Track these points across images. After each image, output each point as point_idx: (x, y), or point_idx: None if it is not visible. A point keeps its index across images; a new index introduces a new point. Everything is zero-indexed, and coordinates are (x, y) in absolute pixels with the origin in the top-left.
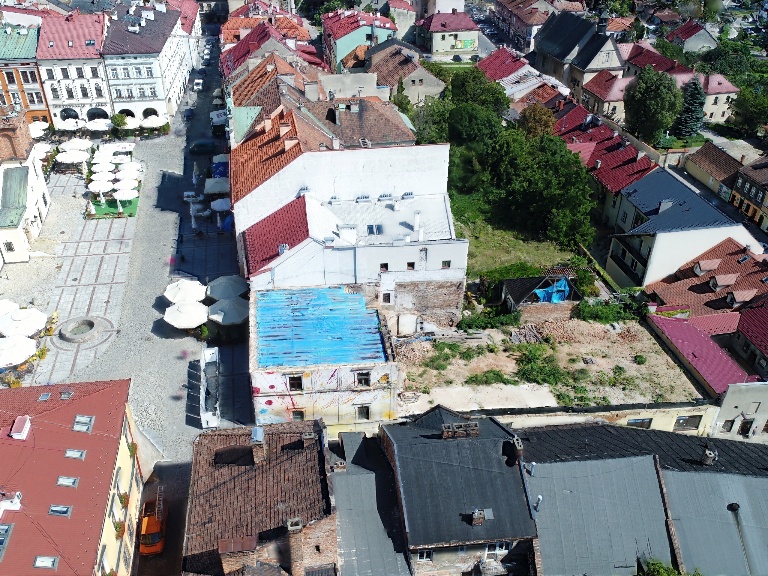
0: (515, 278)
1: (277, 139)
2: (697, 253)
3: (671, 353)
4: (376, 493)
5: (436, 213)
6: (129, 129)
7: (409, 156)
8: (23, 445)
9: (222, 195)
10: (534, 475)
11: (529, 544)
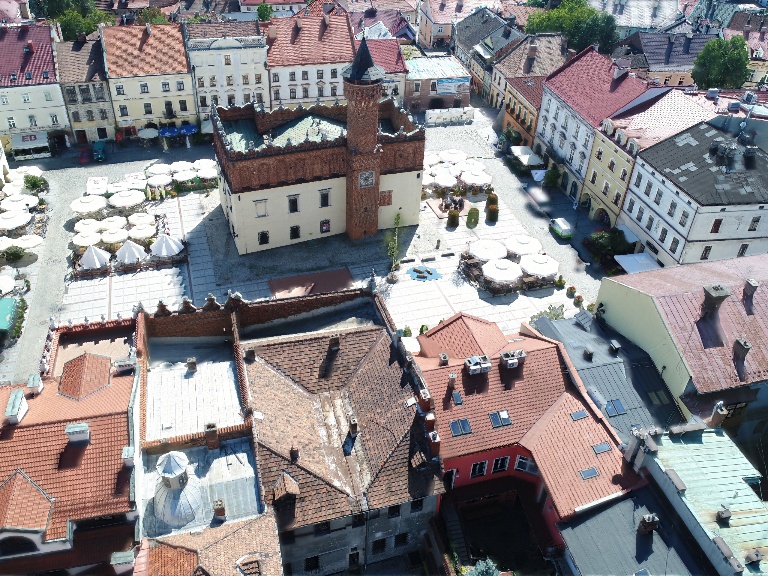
0: None
1: (300, 30)
2: None
3: None
4: None
5: None
6: None
7: None
8: None
9: None
10: None
11: None
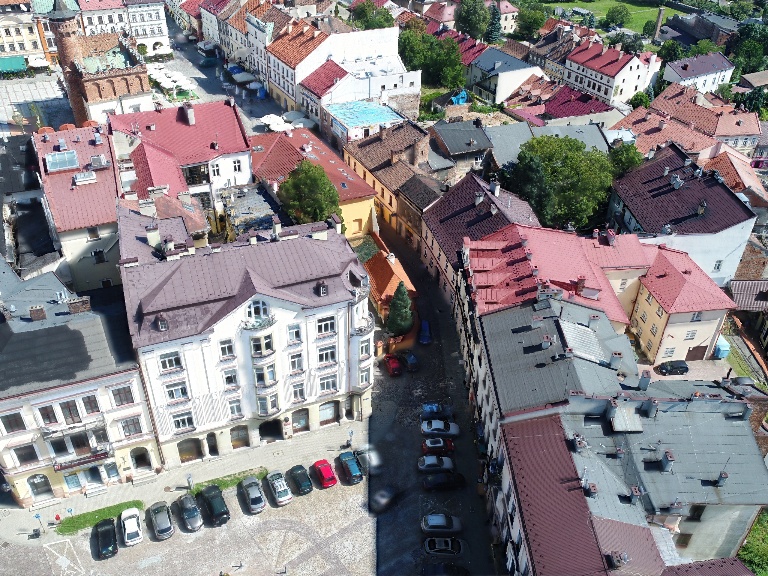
0: (439, 96)
1: (302, 34)
2: (519, 84)
3: (519, 120)
4: (430, 146)
5: (396, 65)
6: (150, 56)
7: (380, 34)
8: None
9: (246, 83)
10: (487, 131)
11: (491, 153)
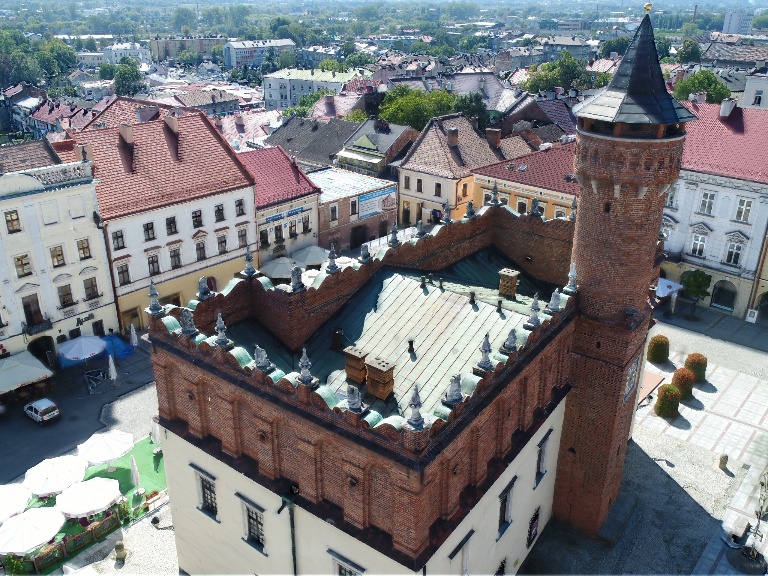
0: None
1: (133, 147)
2: None
3: None
4: None
5: None
6: None
7: None
8: None
9: None
10: None
11: None
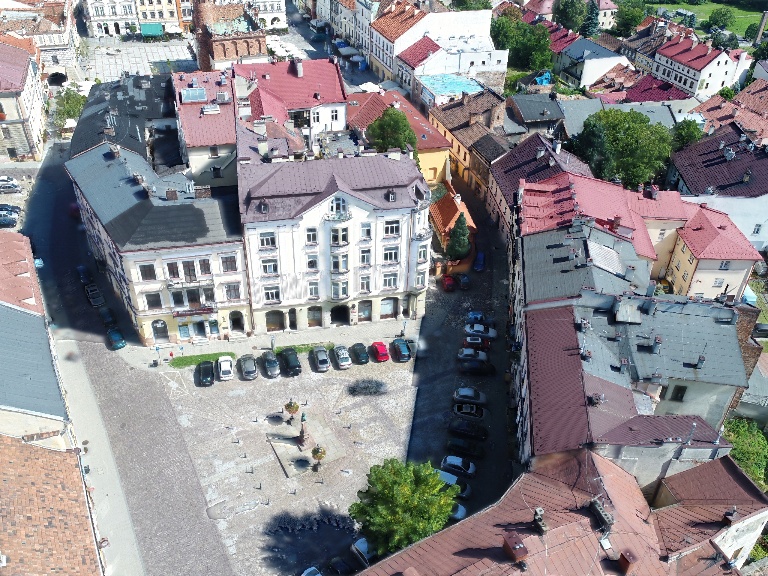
0: (524, 76)
1: (403, 13)
2: (605, 72)
3: None
4: (507, 113)
5: (487, 44)
6: None
7: (474, 16)
8: (385, 97)
9: None
10: (561, 104)
11: (562, 123)
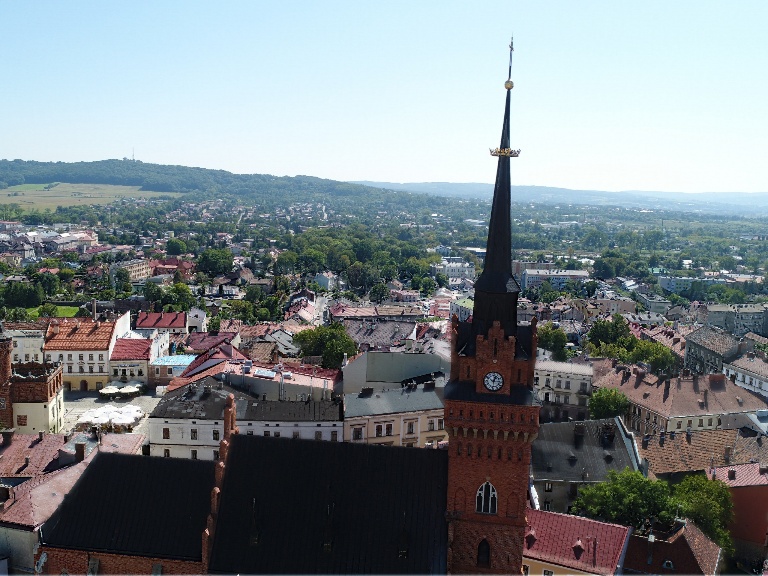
0: None
1: (78, 329)
2: None
3: None
4: None
5: (137, 336)
6: None
7: None
8: None
9: None
10: None
11: None
